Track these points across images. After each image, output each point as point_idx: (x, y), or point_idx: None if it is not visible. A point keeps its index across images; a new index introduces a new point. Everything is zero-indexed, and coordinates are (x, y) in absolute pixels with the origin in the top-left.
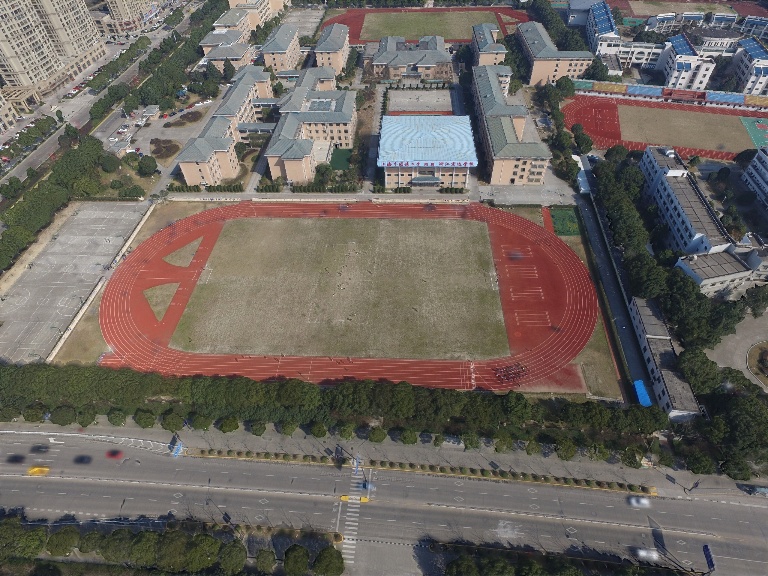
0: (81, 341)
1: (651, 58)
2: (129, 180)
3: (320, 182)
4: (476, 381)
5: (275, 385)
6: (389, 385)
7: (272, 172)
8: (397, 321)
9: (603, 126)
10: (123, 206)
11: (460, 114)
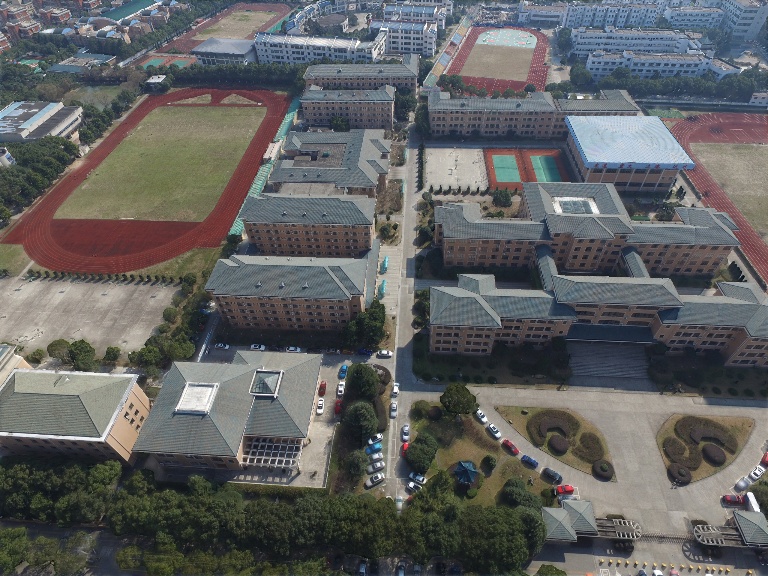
0: None
1: (384, 45)
2: None
3: None
4: None
5: None
6: None
7: (721, 263)
8: None
9: (503, 85)
10: None
11: (490, 145)
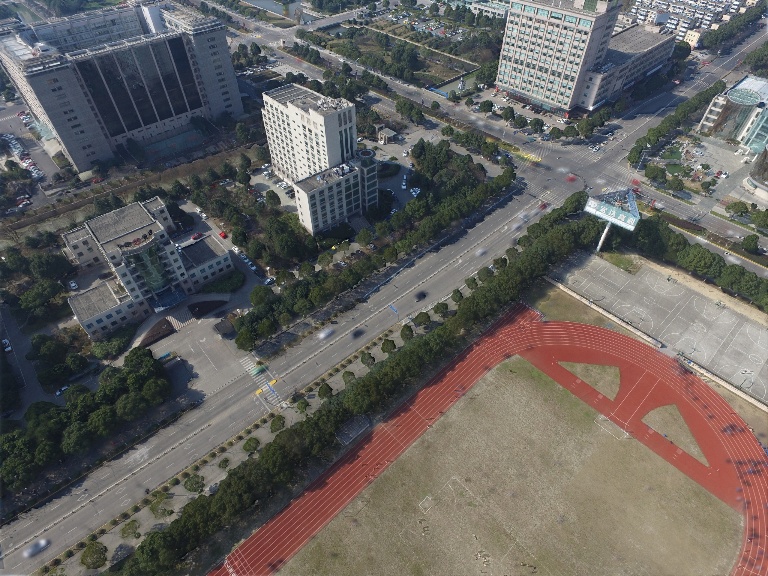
0: (571, 308)
1: None
2: None
3: None
4: (227, 573)
5: (387, 383)
6: (291, 452)
7: None
8: (372, 572)
9: None
10: None
11: None
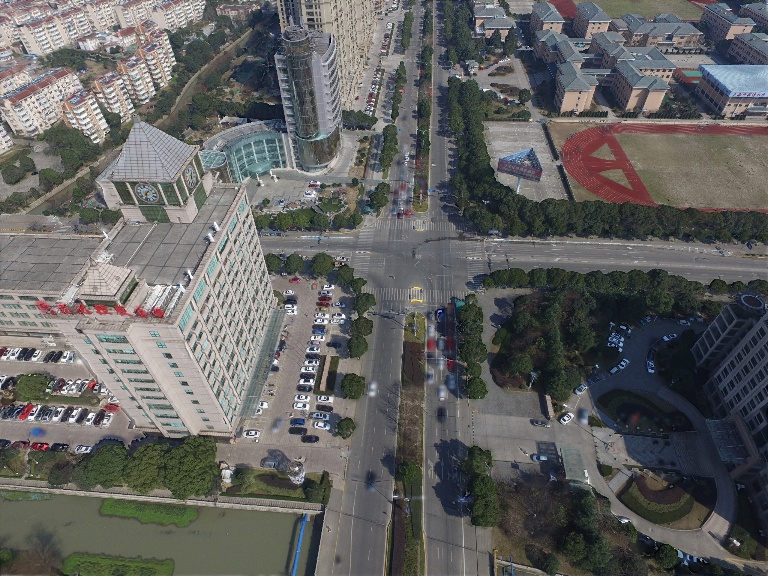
0: (586, 199)
1: None
2: (516, 106)
3: (665, 112)
4: None
5: None
6: None
7: (629, 103)
8: None
9: None
10: (520, 124)
11: None
